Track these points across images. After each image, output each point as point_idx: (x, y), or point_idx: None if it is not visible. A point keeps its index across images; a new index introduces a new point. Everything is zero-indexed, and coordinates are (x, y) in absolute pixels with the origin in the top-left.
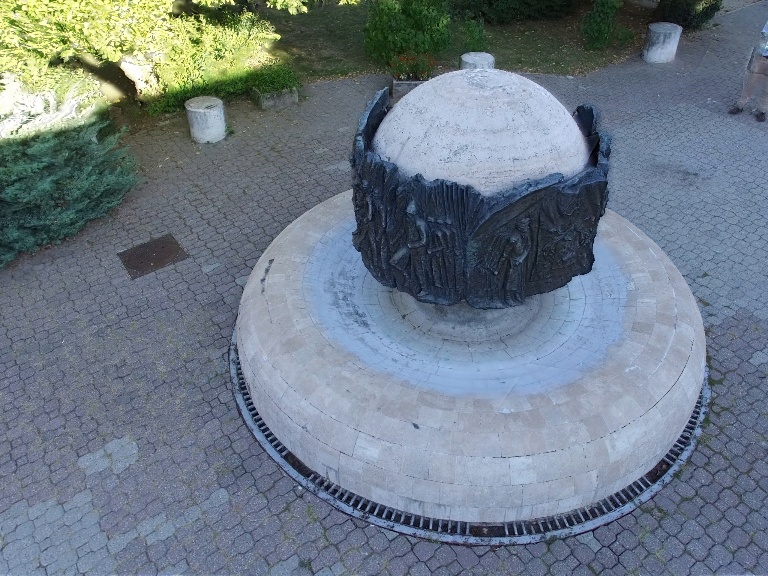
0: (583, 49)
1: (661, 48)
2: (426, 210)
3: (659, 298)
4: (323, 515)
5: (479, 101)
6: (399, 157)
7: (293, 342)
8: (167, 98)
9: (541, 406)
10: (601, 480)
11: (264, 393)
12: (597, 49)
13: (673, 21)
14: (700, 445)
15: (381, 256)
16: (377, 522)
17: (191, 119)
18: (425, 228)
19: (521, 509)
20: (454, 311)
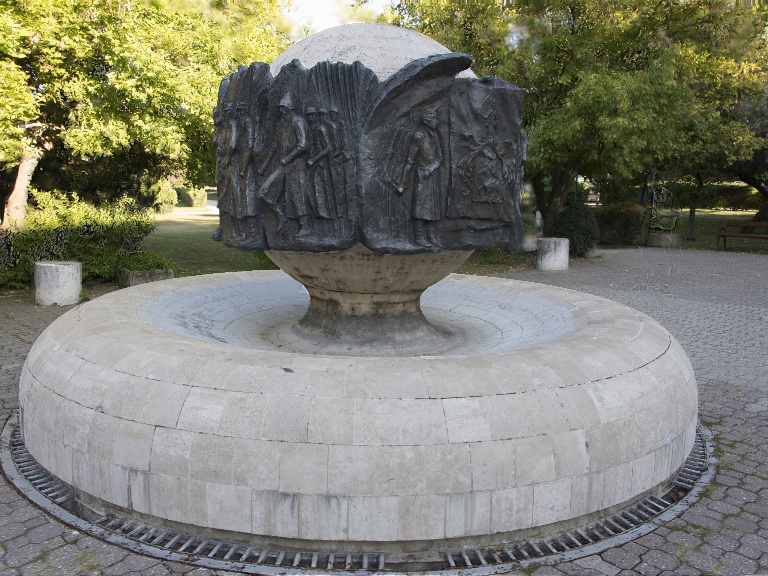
0: (479, 264)
1: (554, 256)
2: (305, 100)
3: (612, 309)
4: (109, 561)
5: (367, 24)
6: (273, 77)
7: (106, 327)
8: (16, 271)
9: (482, 355)
10: (593, 454)
11: (43, 391)
12: (492, 264)
13: (560, 236)
14: (721, 469)
15: (246, 196)
16: (212, 564)
17: (39, 276)
18: (304, 126)
19: (471, 501)
20: (350, 331)
